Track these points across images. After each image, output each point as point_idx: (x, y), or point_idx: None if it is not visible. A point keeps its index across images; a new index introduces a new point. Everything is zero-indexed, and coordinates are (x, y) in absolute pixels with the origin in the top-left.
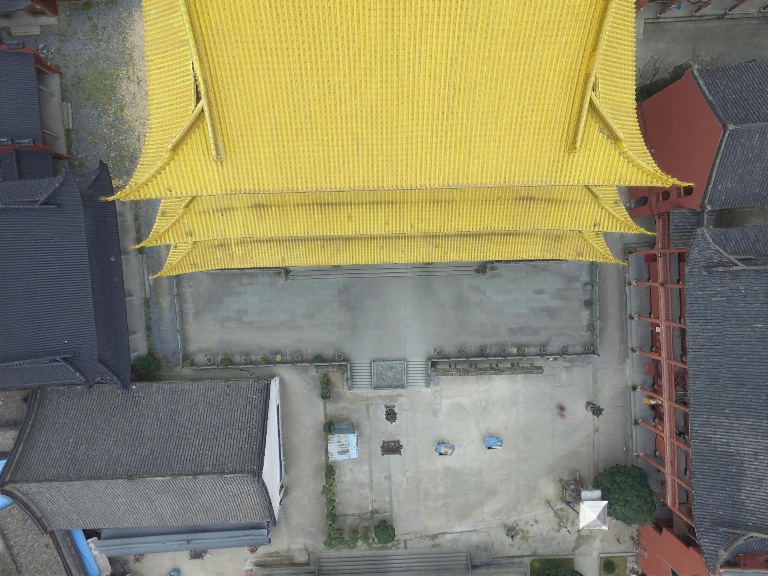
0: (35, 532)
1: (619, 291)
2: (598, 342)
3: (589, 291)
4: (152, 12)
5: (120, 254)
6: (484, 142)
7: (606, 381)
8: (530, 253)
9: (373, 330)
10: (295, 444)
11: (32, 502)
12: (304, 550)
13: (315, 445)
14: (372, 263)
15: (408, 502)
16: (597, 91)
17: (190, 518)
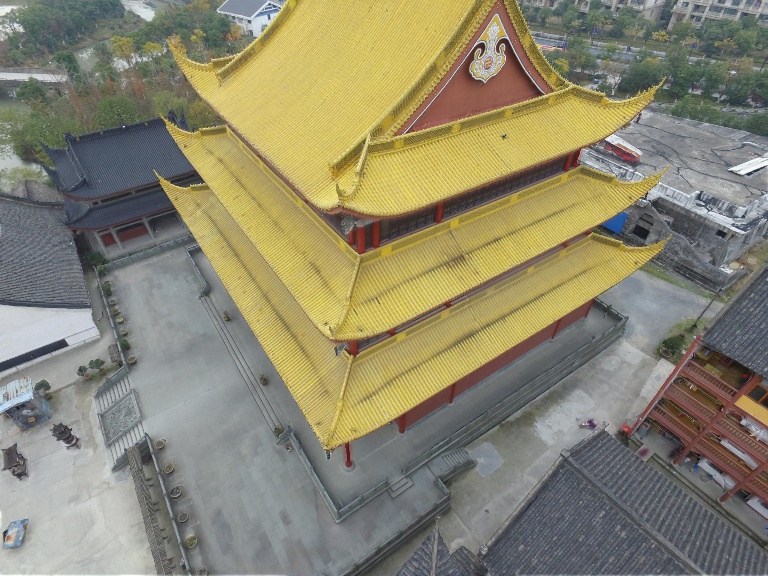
0: None
1: None
2: None
3: None
4: None
5: None
6: None
7: None
8: (296, 385)
9: (171, 376)
10: None
11: None
12: None
13: None
14: (223, 282)
15: None
16: (375, 141)
17: None
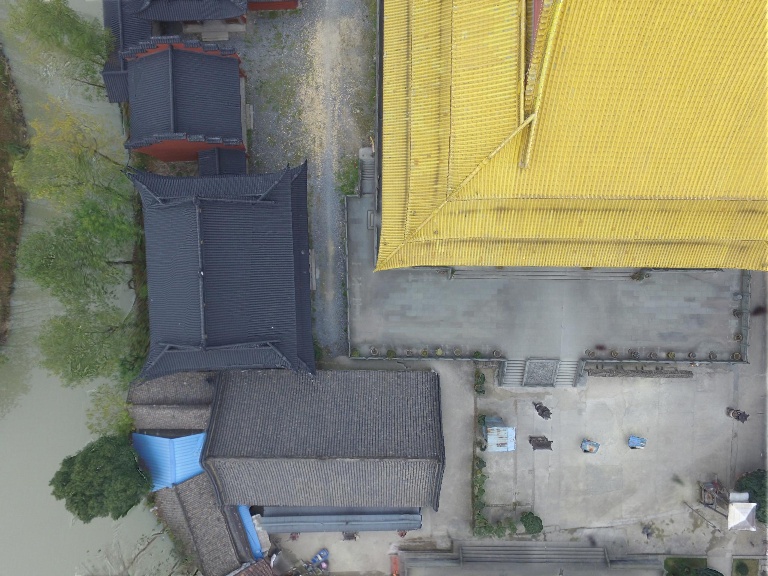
0: (210, 506)
1: (763, 302)
2: (747, 350)
3: (738, 301)
4: (464, 32)
5: (308, 248)
6: (762, 159)
7: (747, 388)
8: (713, 262)
9: (529, 330)
10: (445, 435)
11: (219, 477)
12: (447, 537)
13: (464, 437)
14: None
15: (549, 496)
16: None
17: (357, 500)
